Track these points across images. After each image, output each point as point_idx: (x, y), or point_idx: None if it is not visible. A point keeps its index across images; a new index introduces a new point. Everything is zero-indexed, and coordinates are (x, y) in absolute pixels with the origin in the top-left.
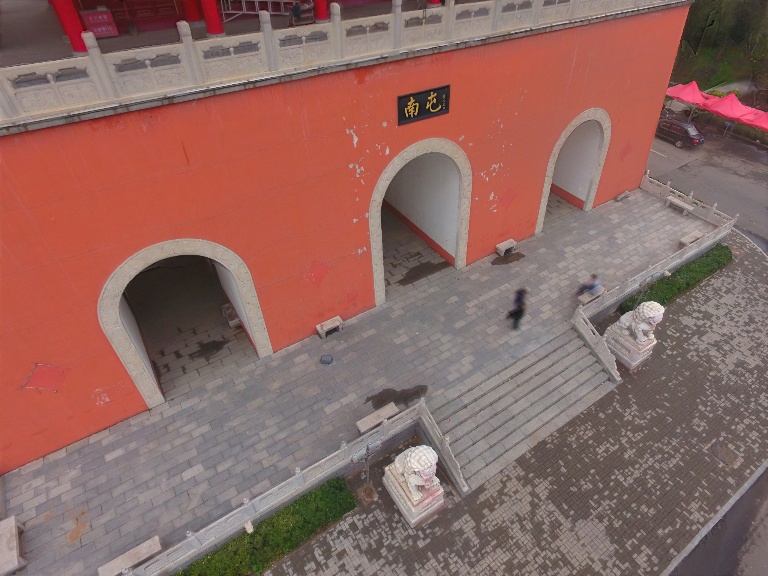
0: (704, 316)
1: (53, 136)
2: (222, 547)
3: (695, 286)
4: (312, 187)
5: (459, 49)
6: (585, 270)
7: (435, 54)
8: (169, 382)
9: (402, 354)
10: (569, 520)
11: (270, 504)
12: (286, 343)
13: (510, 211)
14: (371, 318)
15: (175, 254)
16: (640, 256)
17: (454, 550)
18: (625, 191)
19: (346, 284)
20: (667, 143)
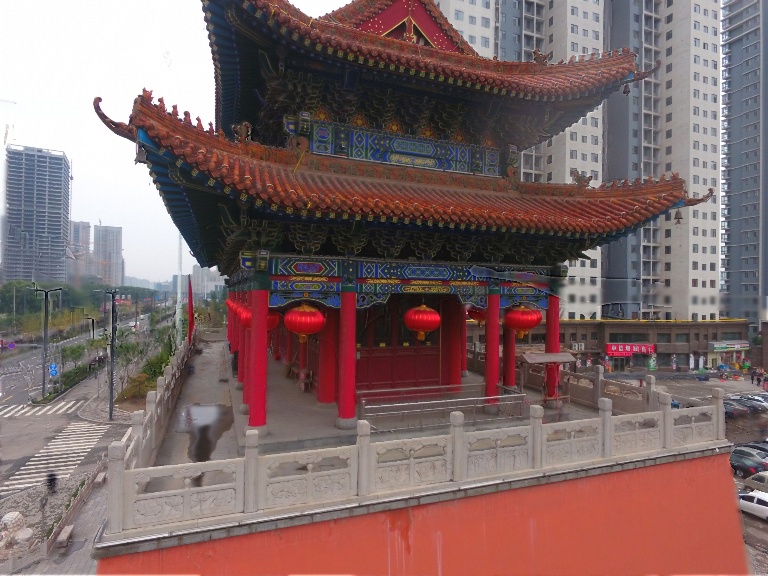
0: None
1: None
2: None
3: None
4: None
5: None
6: None
7: None
8: None
9: None
10: None
11: None
12: None
13: None
14: None
15: None
16: None
17: None
18: None
19: None
20: None
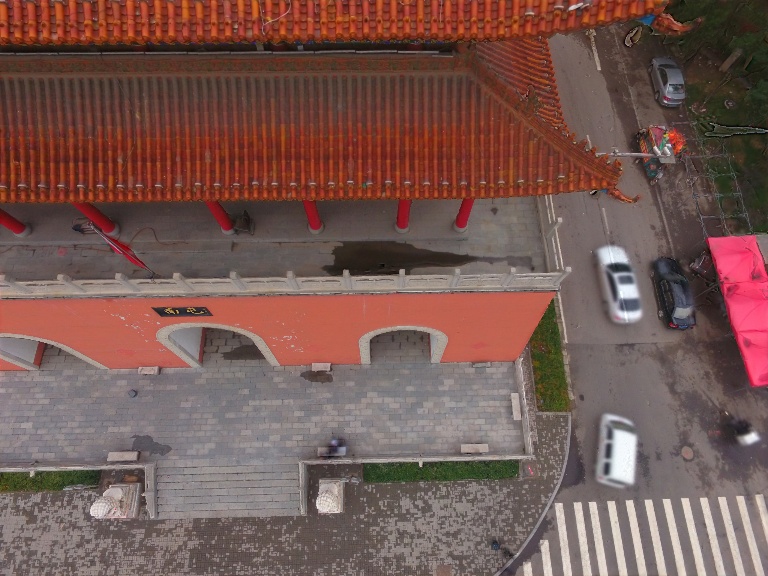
0: (423, 508)
1: None
2: (22, 472)
3: (450, 480)
4: (97, 328)
5: None
6: (361, 422)
7: None
8: (48, 357)
9: (177, 416)
10: (189, 569)
11: (45, 469)
12: (119, 367)
13: (322, 353)
14: (182, 376)
15: (5, 336)
16: (418, 436)
17: (123, 542)
18: (488, 362)
19: (157, 358)
20: (655, 302)
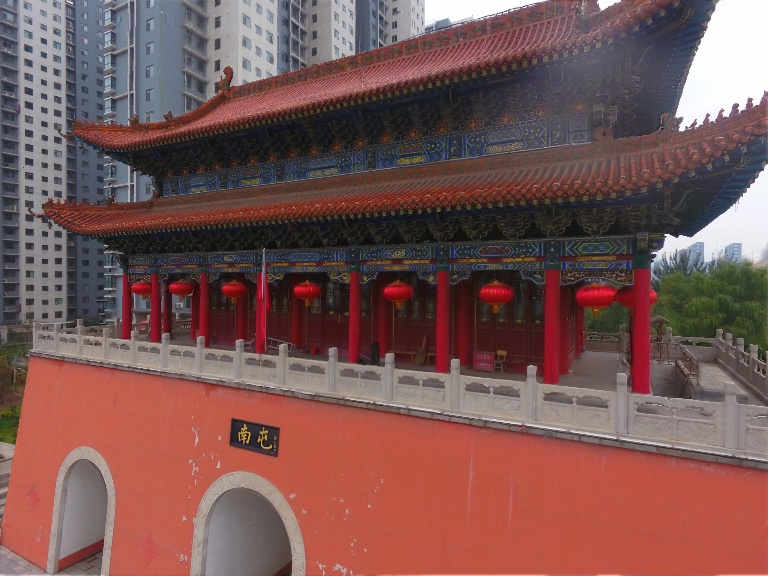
0: None
1: (83, 368)
2: None
3: None
4: (164, 462)
5: (288, 396)
6: None
7: (265, 393)
8: (76, 567)
9: None
10: None
11: None
12: None
13: None
14: None
15: (92, 460)
16: None
17: None
18: None
19: None
20: None
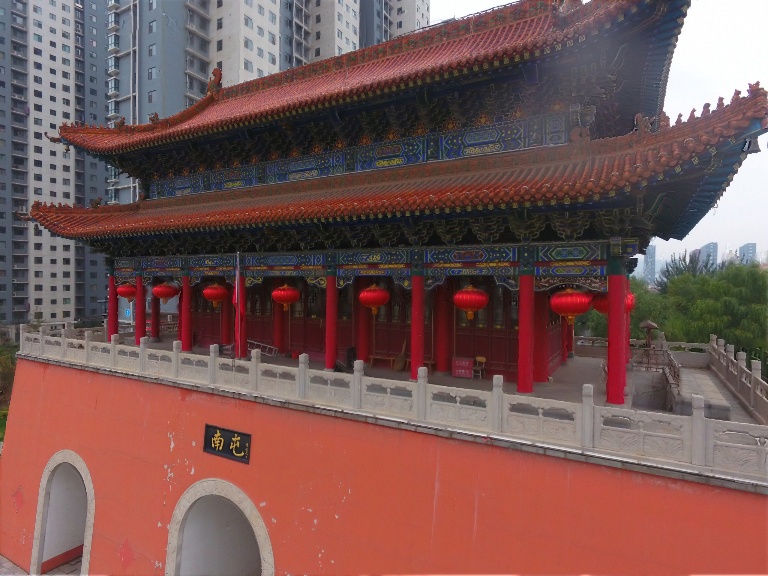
0: None
1: (66, 371)
2: None
3: None
4: None
5: (259, 403)
6: None
7: (238, 399)
8: (59, 570)
9: None
10: None
11: None
12: None
13: None
14: None
15: None
16: None
17: None
18: None
19: None
20: None
